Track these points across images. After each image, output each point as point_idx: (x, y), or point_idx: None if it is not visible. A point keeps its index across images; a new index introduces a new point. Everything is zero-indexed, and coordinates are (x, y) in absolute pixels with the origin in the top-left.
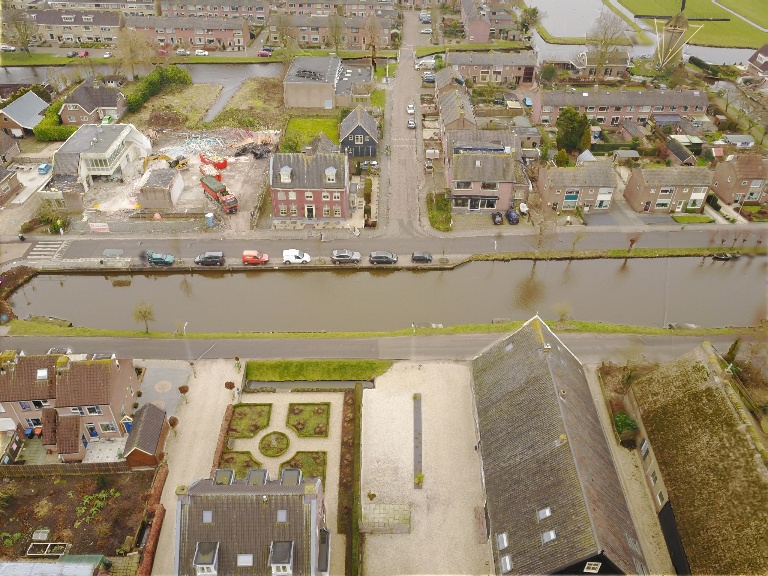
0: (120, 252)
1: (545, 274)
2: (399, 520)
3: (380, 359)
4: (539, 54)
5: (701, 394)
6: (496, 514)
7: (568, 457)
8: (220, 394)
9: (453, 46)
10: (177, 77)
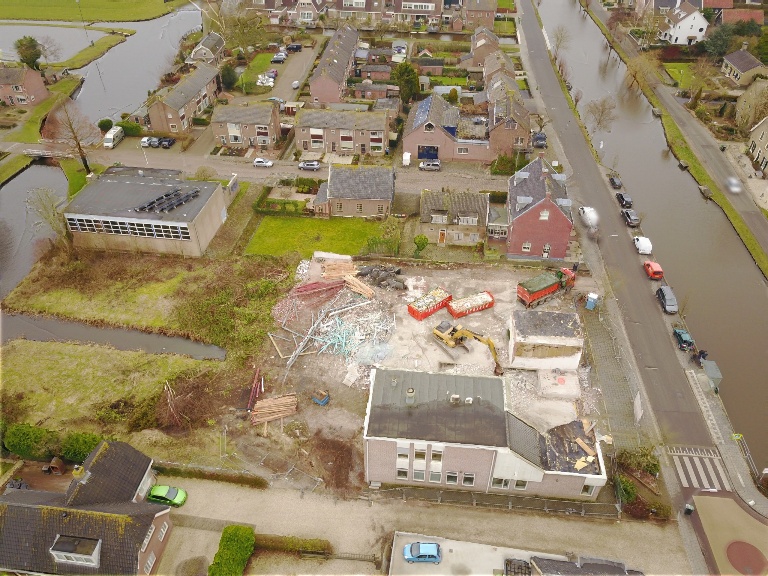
0: None
1: (595, 148)
2: None
3: (761, 211)
4: (153, 71)
5: None
6: None
7: None
8: None
9: (34, 117)
10: None
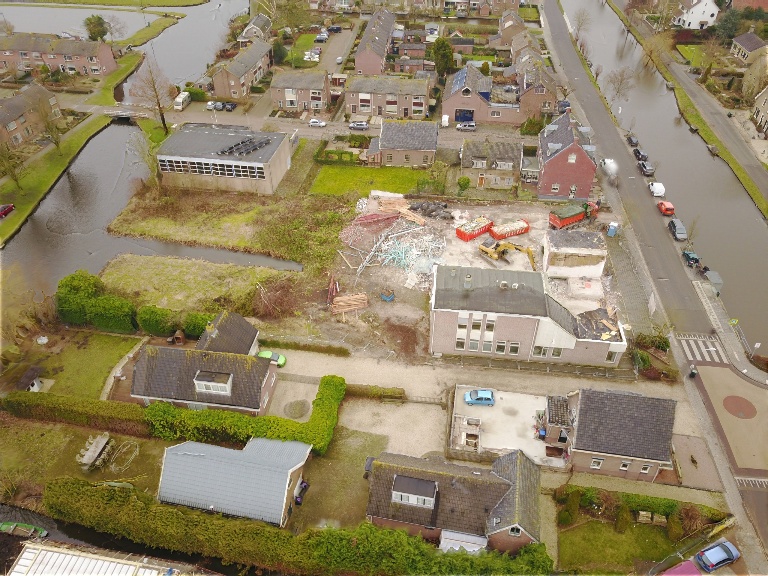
0: None
1: None
2: None
3: (762, 165)
4: (210, 47)
5: None
6: None
7: None
8: None
9: (107, 85)
10: (92, 287)
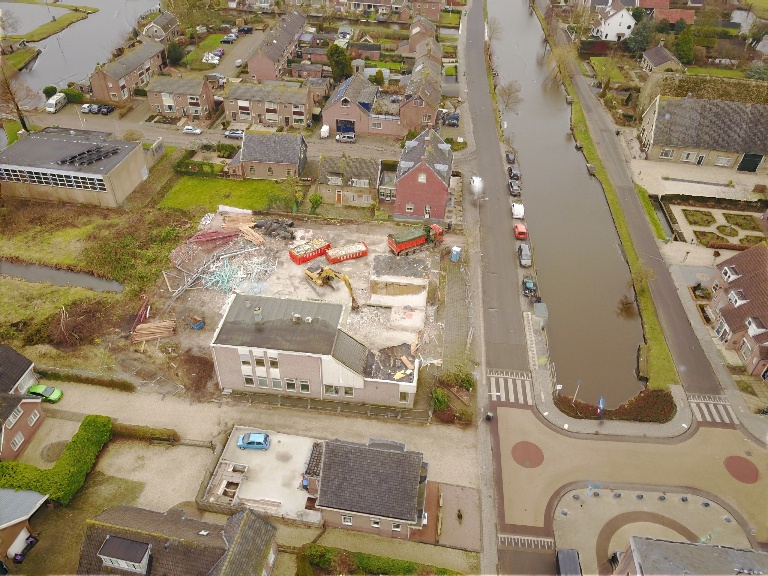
0: (540, 304)
1: None
2: (756, 195)
3: (635, 187)
4: (105, 45)
5: (681, 84)
6: (765, 150)
7: (759, 107)
8: (696, 251)
9: None
10: None
